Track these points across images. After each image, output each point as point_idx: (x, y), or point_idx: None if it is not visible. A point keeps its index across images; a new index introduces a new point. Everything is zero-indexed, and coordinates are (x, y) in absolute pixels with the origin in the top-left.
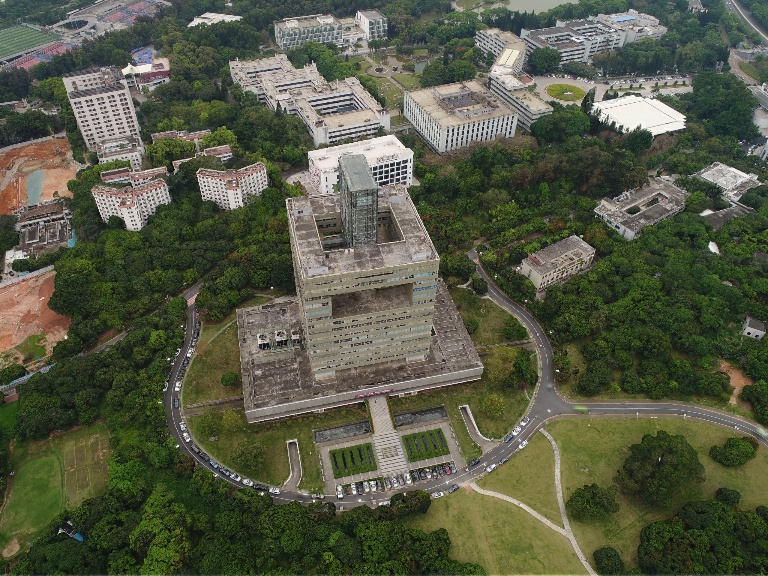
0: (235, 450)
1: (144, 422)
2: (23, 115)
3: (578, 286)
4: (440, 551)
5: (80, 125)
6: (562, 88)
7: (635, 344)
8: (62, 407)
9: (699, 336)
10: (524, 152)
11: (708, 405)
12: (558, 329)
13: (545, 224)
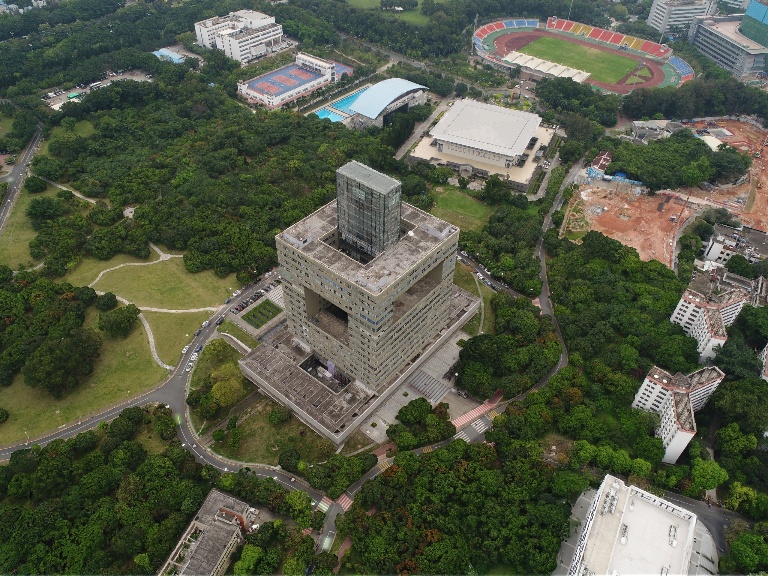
0: None
1: None
2: None
3: None
4: None
5: None
6: None
7: None
8: None
9: None
10: None
11: None
12: None
13: None
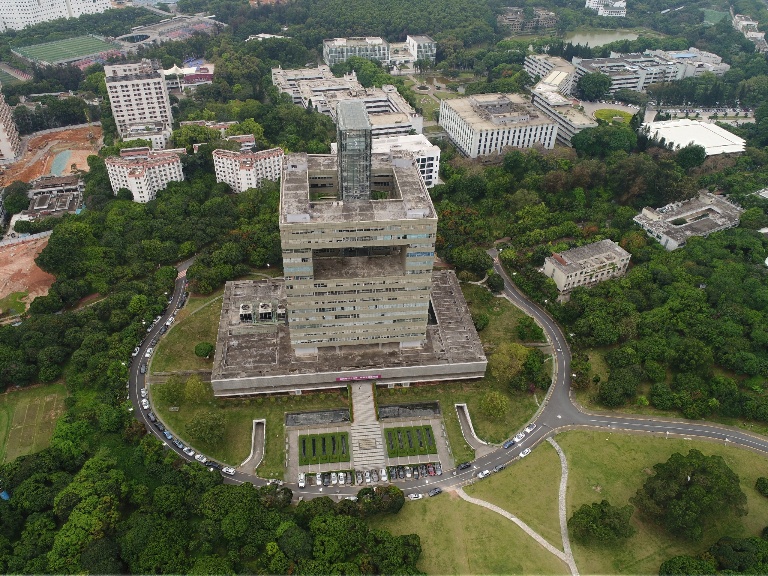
0: (192, 420)
1: (104, 384)
2: (64, 101)
3: (607, 290)
4: (406, 558)
5: (113, 110)
6: (611, 113)
7: (669, 354)
8: (24, 361)
9: (748, 352)
10: (562, 162)
11: (756, 432)
12: (580, 332)
13: (576, 228)
